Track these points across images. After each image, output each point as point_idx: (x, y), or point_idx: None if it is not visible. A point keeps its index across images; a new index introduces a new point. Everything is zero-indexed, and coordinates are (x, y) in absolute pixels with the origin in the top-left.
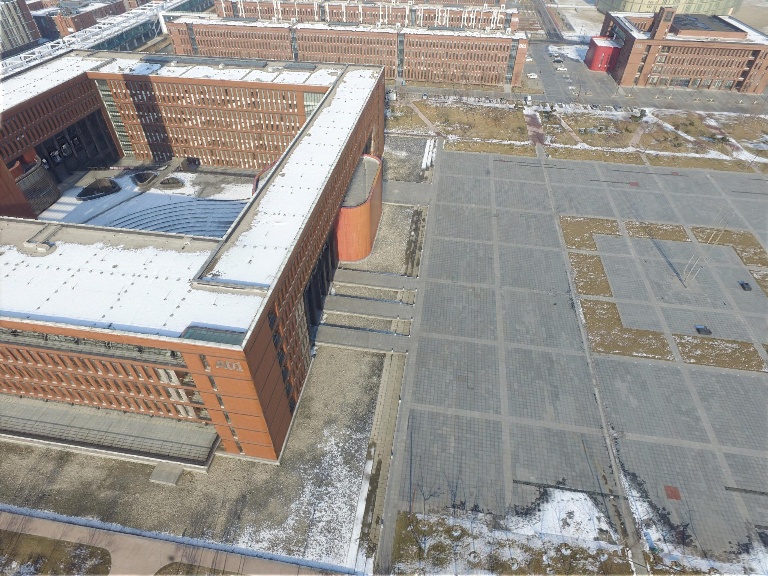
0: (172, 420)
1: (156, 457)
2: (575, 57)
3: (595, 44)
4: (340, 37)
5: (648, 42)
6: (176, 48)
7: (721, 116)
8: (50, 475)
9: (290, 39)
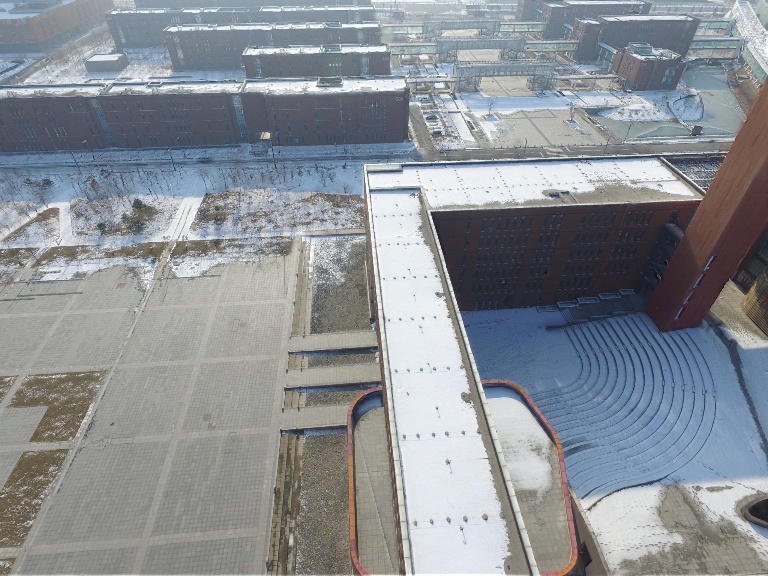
0: None
1: None
2: None
3: None
4: None
5: None
6: None
7: None
8: None
9: None
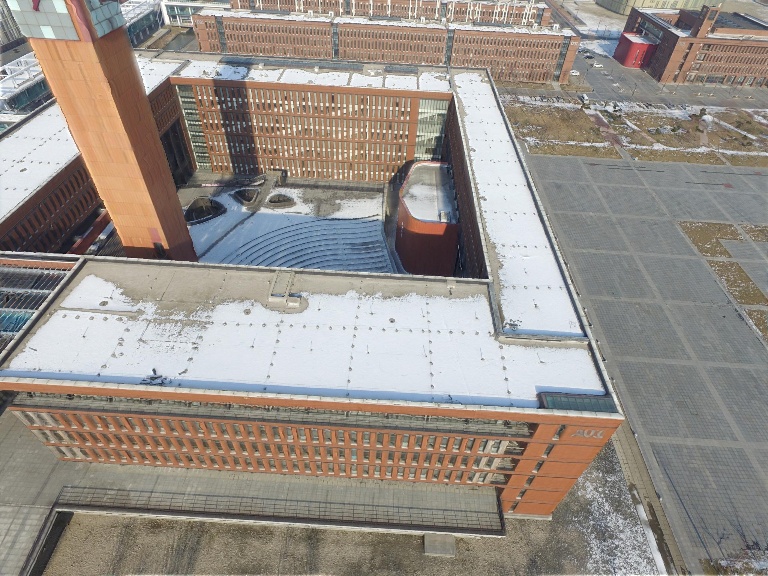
0: (438, 484)
1: (446, 531)
2: (602, 53)
3: (629, 41)
4: (386, 33)
5: (691, 40)
6: (201, 43)
7: (766, 113)
8: (307, 560)
9: (331, 34)
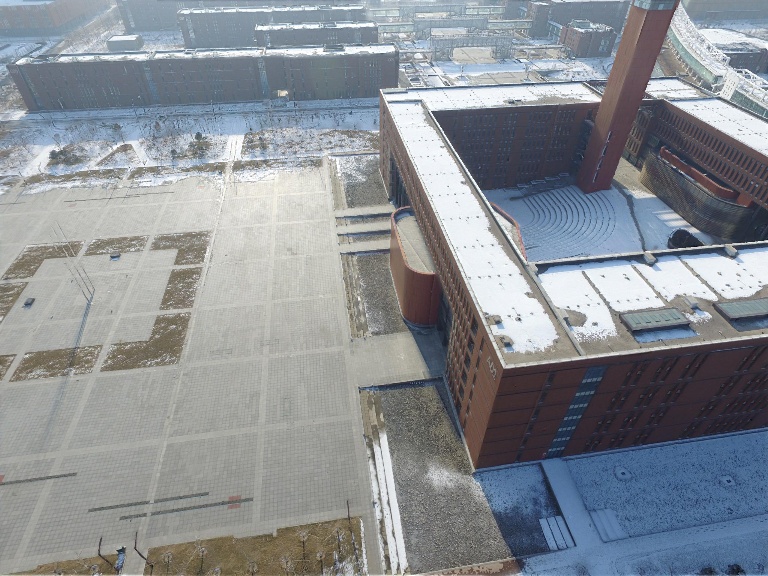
0: None
1: None
2: None
3: None
4: None
5: None
6: None
7: None
8: None
9: None
